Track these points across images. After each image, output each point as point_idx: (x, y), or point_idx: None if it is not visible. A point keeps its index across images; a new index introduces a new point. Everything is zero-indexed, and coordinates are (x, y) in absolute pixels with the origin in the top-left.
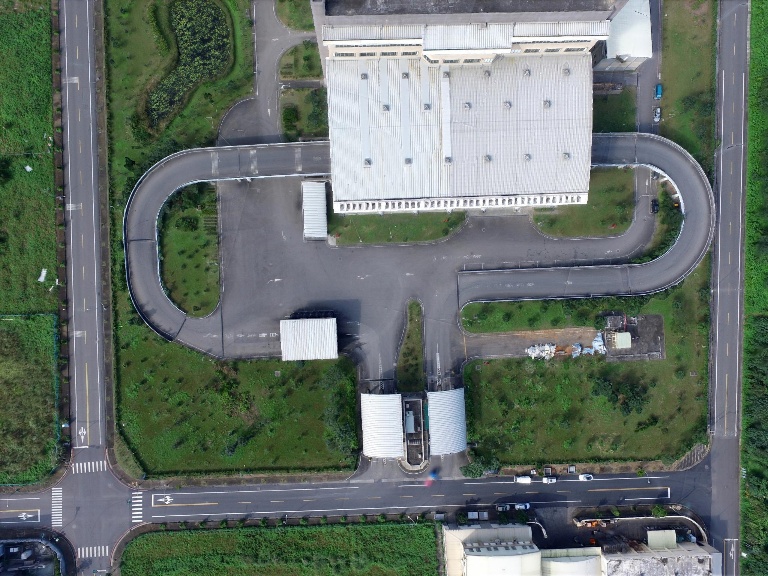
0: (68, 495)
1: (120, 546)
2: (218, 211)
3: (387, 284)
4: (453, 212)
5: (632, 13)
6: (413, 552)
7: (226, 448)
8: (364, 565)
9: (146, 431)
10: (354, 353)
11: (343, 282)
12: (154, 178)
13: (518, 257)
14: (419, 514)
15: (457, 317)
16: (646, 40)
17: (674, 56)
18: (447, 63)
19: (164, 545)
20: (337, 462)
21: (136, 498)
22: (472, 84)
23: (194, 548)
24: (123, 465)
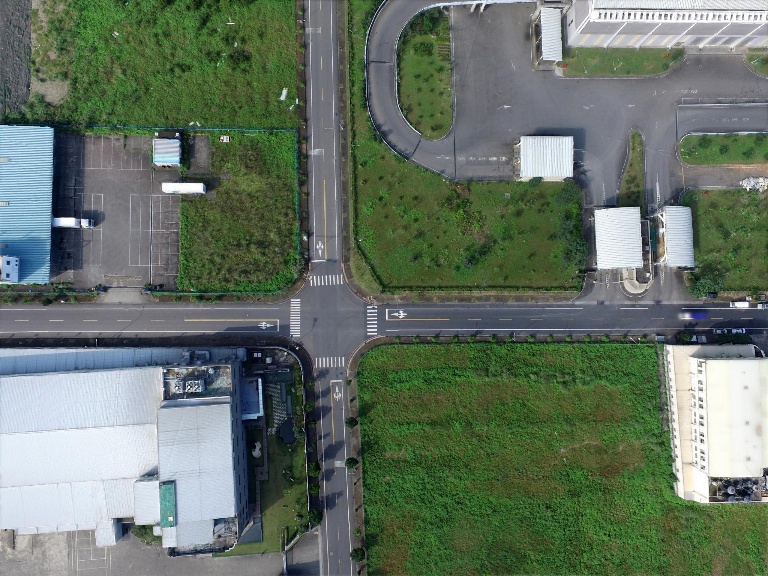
0: (306, 306)
1: (356, 357)
2: (451, 39)
3: (610, 114)
4: (672, 48)
5: None
6: (636, 371)
7: (465, 260)
8: (590, 382)
9: (382, 247)
10: (579, 179)
11: (569, 111)
12: (396, 1)
13: (733, 94)
14: (640, 336)
15: (676, 149)
16: None
17: None
18: None
19: (398, 357)
20: (563, 283)
21: (371, 312)
22: None
23: (427, 361)
24: (359, 279)
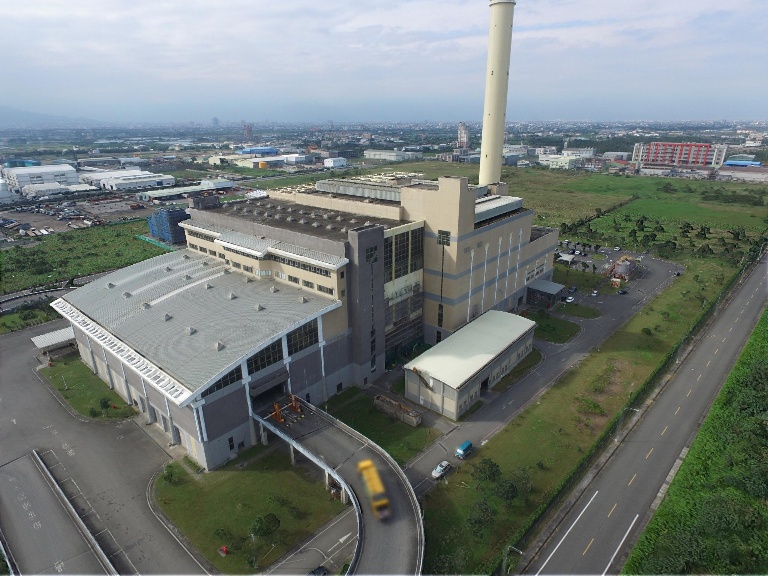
0: None
1: None
2: None
3: None
4: (130, 407)
5: (464, 353)
6: None
7: None
8: None
9: None
10: None
11: None
12: None
13: (91, 487)
14: None
15: None
16: (461, 374)
17: (520, 435)
18: (235, 267)
19: None
20: None
21: None
22: (232, 281)
23: None
24: None
